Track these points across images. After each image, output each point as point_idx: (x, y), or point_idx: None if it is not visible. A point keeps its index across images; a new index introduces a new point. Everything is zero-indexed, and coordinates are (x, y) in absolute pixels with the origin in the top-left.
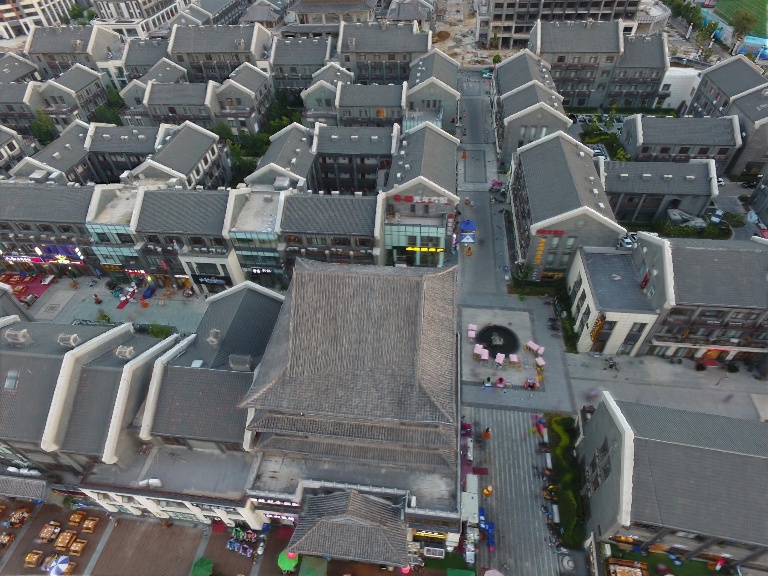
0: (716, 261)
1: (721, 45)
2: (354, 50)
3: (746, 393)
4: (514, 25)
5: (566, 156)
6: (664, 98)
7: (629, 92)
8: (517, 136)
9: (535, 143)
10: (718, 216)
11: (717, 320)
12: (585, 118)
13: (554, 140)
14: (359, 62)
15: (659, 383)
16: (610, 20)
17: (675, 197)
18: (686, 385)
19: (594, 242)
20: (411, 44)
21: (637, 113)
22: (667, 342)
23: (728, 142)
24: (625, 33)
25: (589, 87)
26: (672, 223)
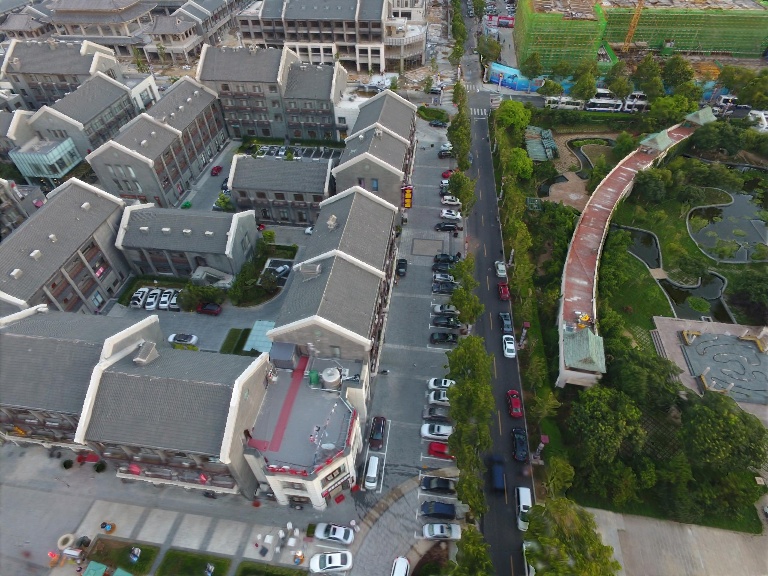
0: (29, 352)
1: (483, 70)
2: (19, 70)
3: (92, 499)
4: (265, 43)
5: (44, 209)
6: (345, 131)
7: (307, 124)
8: (108, 175)
9: (56, 189)
10: (276, 273)
11: (34, 419)
12: (264, 150)
13: (67, 187)
14: (31, 83)
15: (13, 482)
16: (356, 41)
17: (197, 254)
18: (39, 486)
19: (5, 313)
20: (77, 66)
21: (322, 146)
22: (17, 437)
23: (318, 189)
24: (374, 55)
25: (266, 117)
26: (195, 282)
